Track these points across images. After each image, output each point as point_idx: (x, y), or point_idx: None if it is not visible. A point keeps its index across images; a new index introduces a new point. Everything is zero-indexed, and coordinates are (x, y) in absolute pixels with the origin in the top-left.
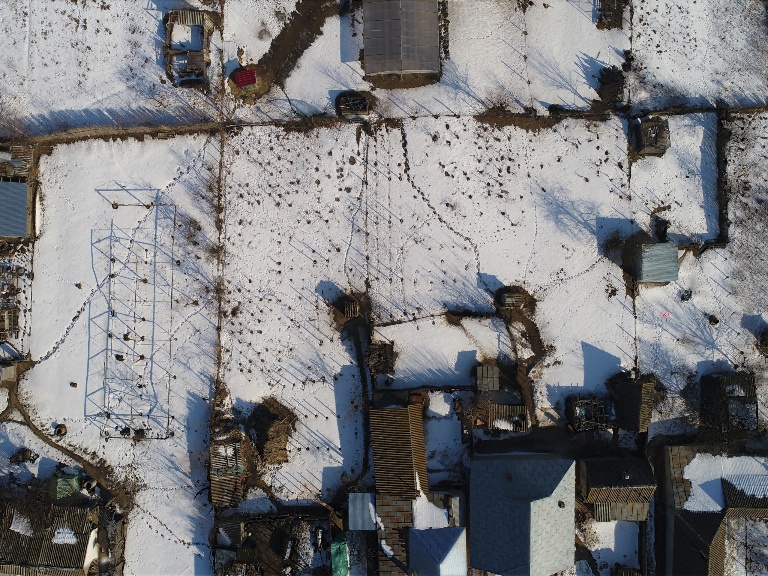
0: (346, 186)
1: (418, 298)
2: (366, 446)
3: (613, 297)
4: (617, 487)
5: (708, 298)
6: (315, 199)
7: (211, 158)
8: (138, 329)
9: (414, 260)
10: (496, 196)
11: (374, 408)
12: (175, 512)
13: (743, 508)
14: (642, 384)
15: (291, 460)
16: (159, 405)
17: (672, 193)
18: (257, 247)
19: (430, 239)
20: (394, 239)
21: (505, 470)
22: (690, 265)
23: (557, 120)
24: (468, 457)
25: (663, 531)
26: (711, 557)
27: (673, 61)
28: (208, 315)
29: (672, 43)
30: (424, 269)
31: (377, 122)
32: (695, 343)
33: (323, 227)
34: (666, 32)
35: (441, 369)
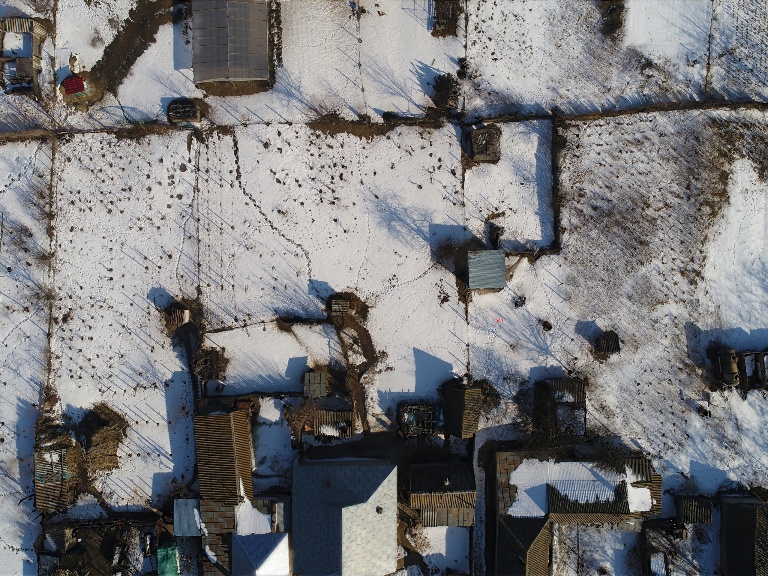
0: (177, 193)
1: (249, 304)
2: None
3: (445, 303)
4: (437, 493)
5: (542, 304)
6: (147, 206)
7: (42, 165)
8: None
9: (245, 267)
10: (328, 203)
11: (198, 414)
12: (4, 518)
13: (564, 513)
14: (465, 390)
15: (122, 466)
16: None
17: (506, 200)
18: (88, 254)
19: (261, 246)
20: (225, 246)
21: (325, 476)
22: (525, 271)
23: (391, 127)
24: (299, 463)
25: (493, 536)
26: (529, 562)
27: (509, 68)
28: (39, 322)
29: (508, 51)
30: (255, 276)
31: (209, 129)
32: (529, 349)
33: (155, 234)
34: (502, 40)
35: (271, 375)
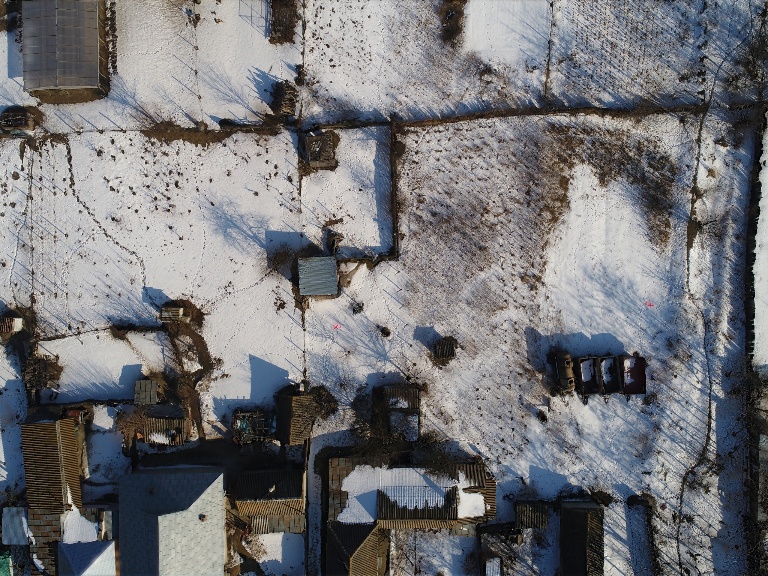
0: (11, 201)
1: (82, 312)
2: None
3: (281, 310)
4: (262, 500)
5: (381, 310)
6: None
7: None
8: None
9: (79, 274)
10: (164, 210)
11: (25, 423)
12: None
13: (391, 520)
14: (292, 397)
15: None
16: None
17: (344, 206)
18: None
19: (95, 253)
20: (59, 254)
21: (150, 484)
22: (363, 278)
23: (227, 134)
24: None
25: None
26: (353, 569)
27: (347, 75)
28: None
29: (346, 57)
30: (88, 283)
31: (42, 137)
32: (367, 355)
33: None
34: (340, 46)
35: (105, 383)
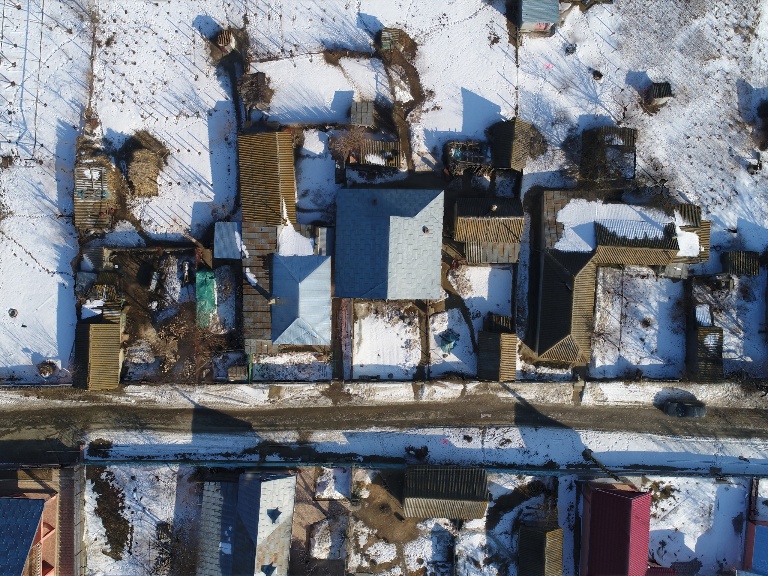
0: None
1: (296, 35)
2: (238, 183)
3: (495, 45)
4: (484, 217)
5: (593, 53)
6: None
7: None
8: (10, 55)
9: None
10: None
11: (243, 134)
12: (40, 240)
13: (612, 246)
14: None
15: (161, 194)
16: (28, 132)
17: None
18: None
19: None
20: None
21: (371, 196)
22: (576, 19)
23: None
24: None
25: (537, 280)
26: (576, 290)
27: None
28: (82, 44)
29: None
30: (303, 6)
31: None
32: (578, 97)
33: None
34: None
35: (317, 107)
